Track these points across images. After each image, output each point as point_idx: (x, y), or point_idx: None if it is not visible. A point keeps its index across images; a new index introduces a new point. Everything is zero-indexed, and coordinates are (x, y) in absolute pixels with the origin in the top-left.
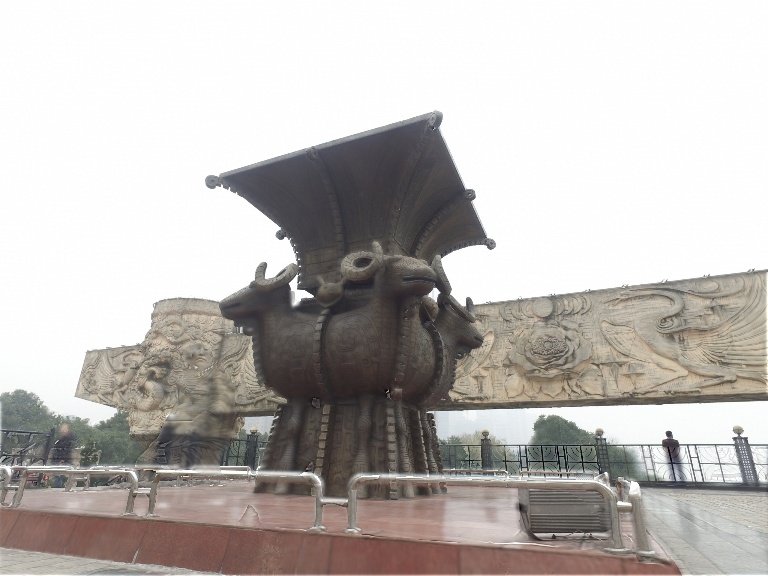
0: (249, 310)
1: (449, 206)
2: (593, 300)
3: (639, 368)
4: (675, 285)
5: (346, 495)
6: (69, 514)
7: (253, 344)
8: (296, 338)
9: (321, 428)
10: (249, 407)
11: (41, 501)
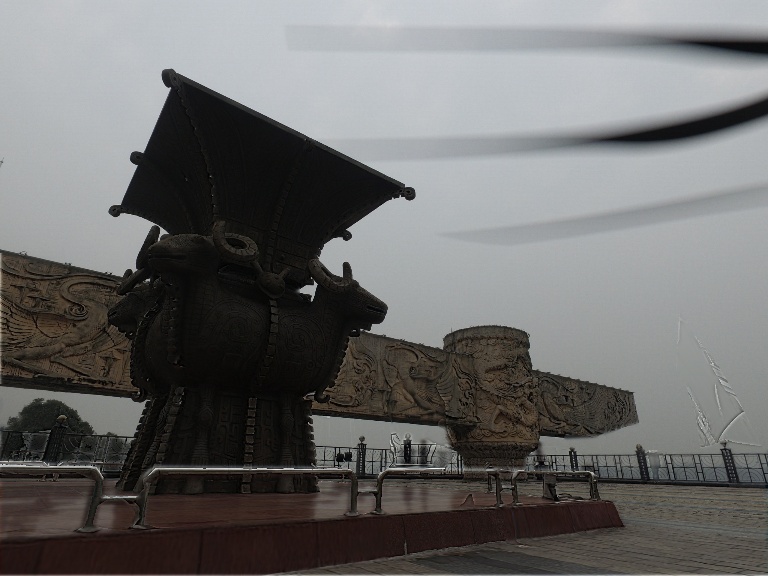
0: (190, 269)
1: (332, 236)
2: None
3: None
4: None
5: (270, 490)
6: (294, 522)
7: (177, 309)
8: (241, 321)
9: (248, 422)
10: None
11: None
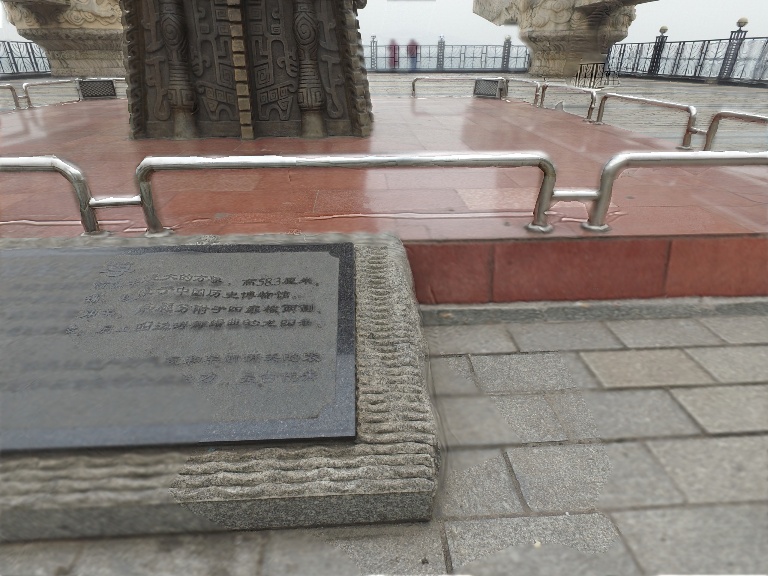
0: None
1: None
2: None
3: None
4: None
5: None
6: None
7: None
8: None
9: None
10: None
11: None
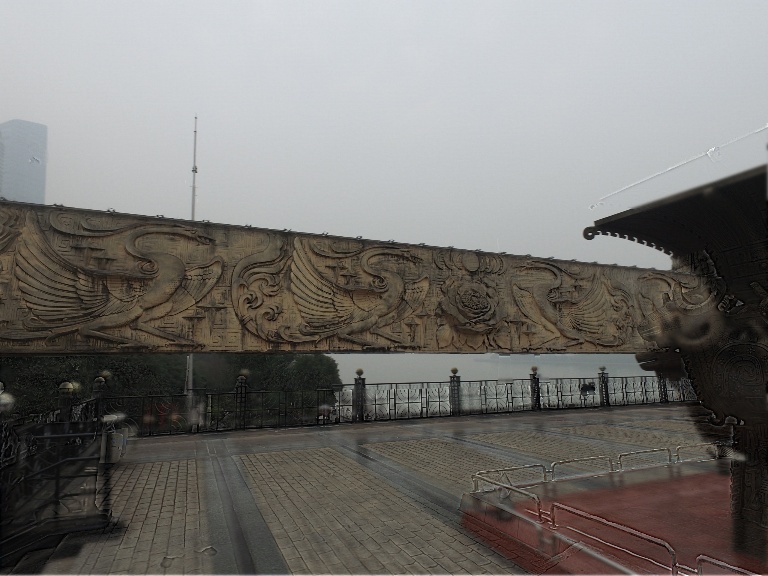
0: None
1: None
2: (507, 263)
3: (533, 328)
4: (557, 263)
5: None
6: None
7: None
8: None
9: None
10: (31, 345)
11: None
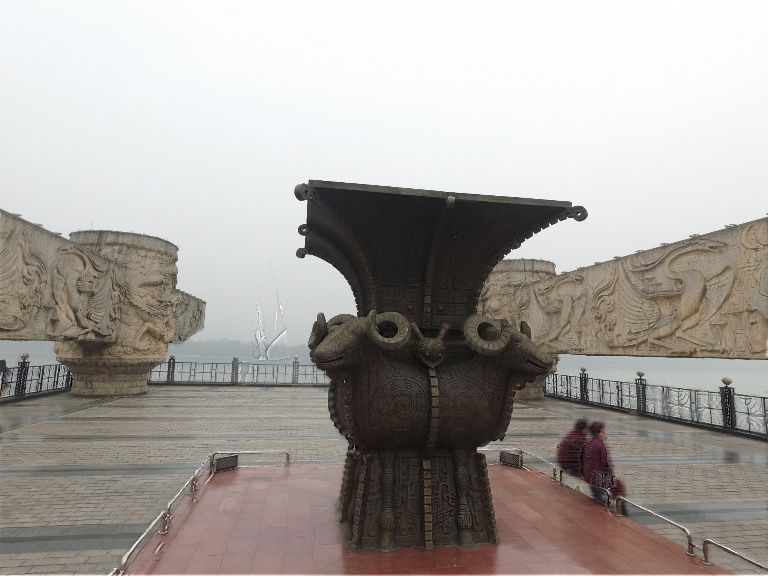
0: None
1: None
2: None
3: None
4: None
5: None
6: None
7: None
8: None
9: None
10: None
11: (688, 572)
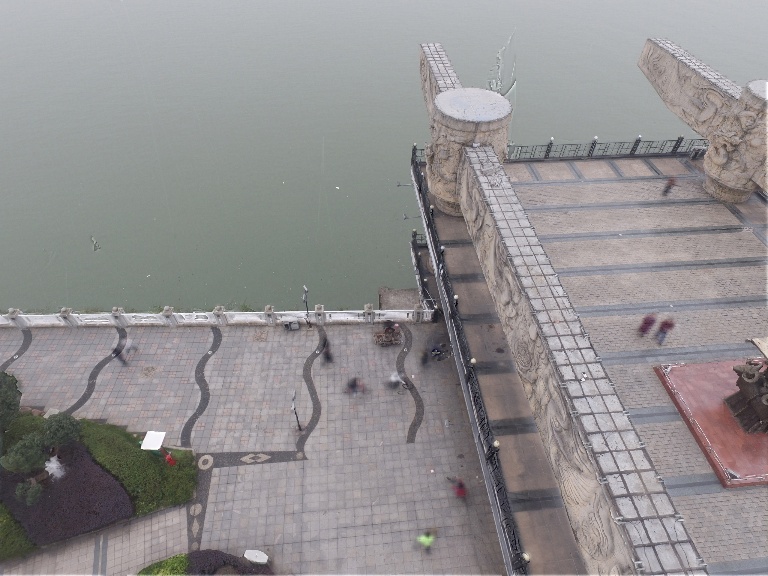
0: None
1: None
2: None
3: None
4: None
5: None
6: None
7: None
8: None
9: None
10: None
11: None
